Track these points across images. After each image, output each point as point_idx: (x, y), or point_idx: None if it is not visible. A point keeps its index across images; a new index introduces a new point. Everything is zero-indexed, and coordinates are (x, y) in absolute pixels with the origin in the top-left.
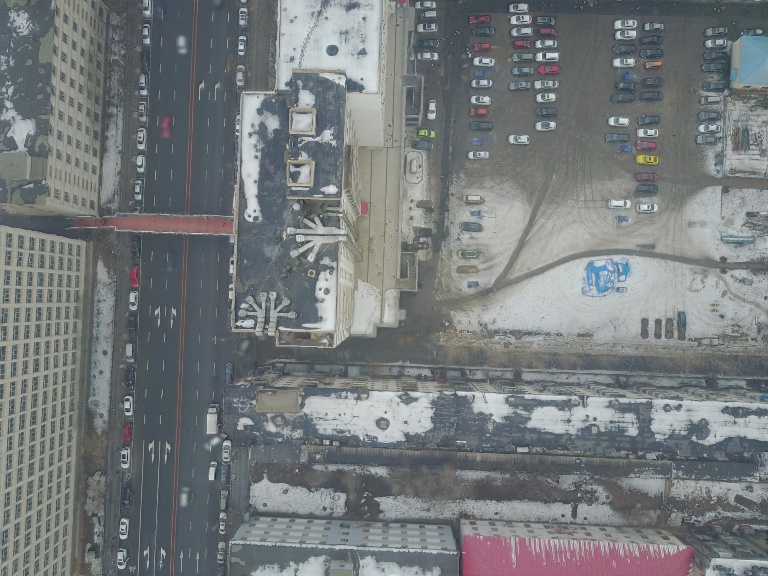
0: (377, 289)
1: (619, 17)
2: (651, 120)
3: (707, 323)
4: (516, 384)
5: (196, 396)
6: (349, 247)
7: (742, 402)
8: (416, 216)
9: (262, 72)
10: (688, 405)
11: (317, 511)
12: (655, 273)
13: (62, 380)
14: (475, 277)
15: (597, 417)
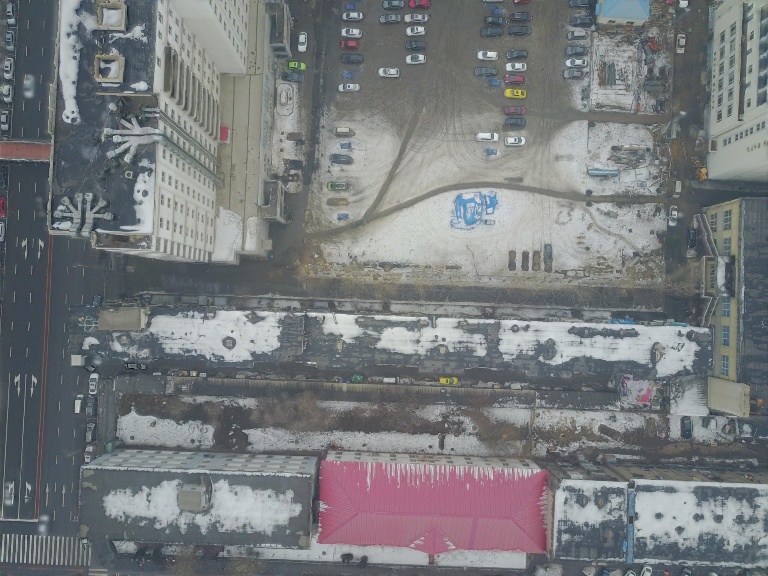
0: (239, 216)
1: None
2: (519, 54)
3: (573, 255)
4: (382, 314)
5: (63, 329)
6: (187, 160)
7: None
8: (287, 148)
9: None
10: (535, 325)
11: (185, 444)
12: (523, 206)
13: None
14: (345, 209)
15: (446, 337)
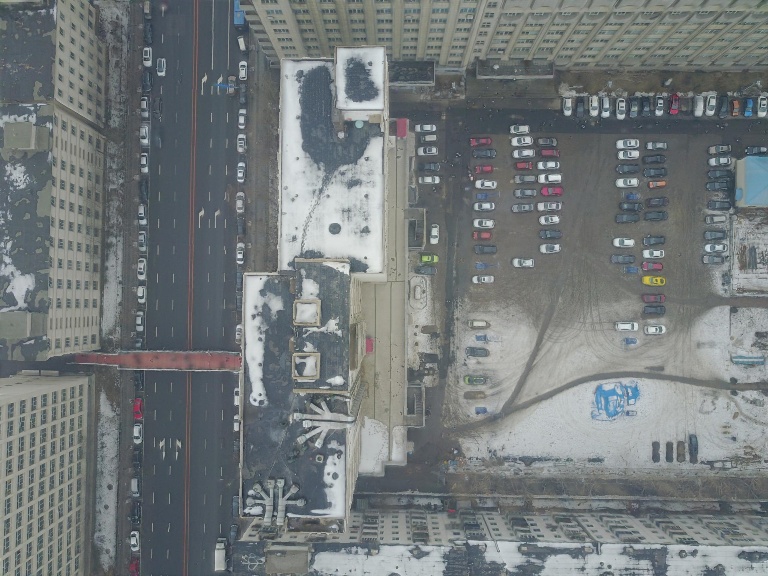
0: (384, 426)
1: (621, 136)
2: (657, 241)
3: (719, 445)
4: (527, 514)
5: (203, 529)
6: None
7: (759, 546)
8: (421, 342)
9: (262, 199)
10: (704, 550)
11: None
12: (665, 395)
13: (67, 527)
14: (483, 403)
15: (612, 564)
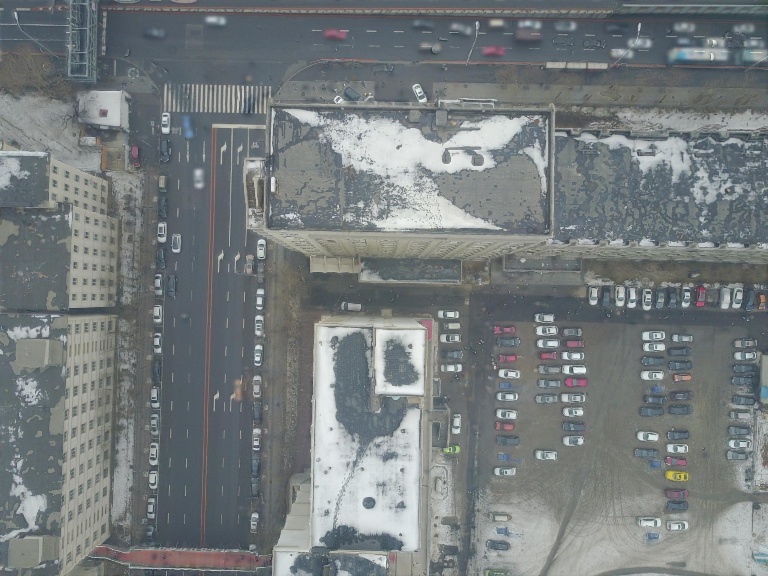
0: None
1: (647, 327)
2: (681, 436)
3: None
4: None
5: None
6: None
7: None
8: (441, 533)
9: (279, 382)
10: None
11: None
12: None
13: None
14: None
15: None
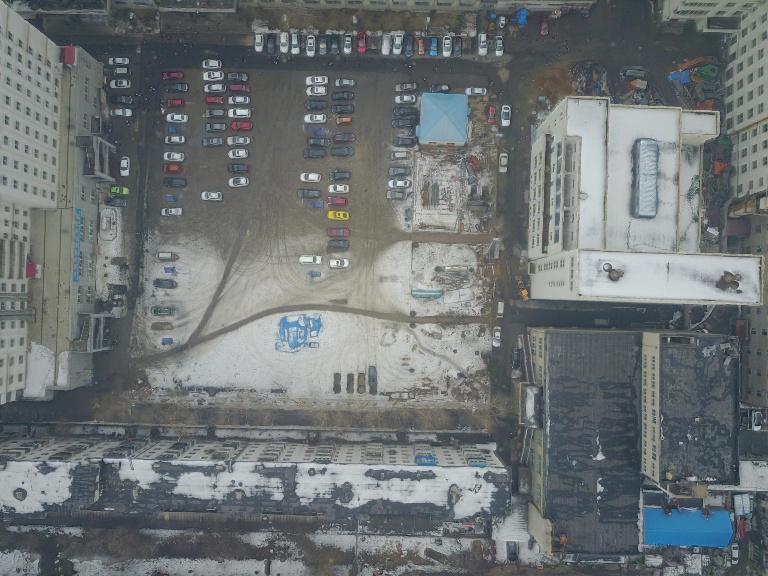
0: (51, 351)
1: (312, 73)
2: (341, 176)
3: (398, 377)
4: (203, 442)
5: None
6: None
7: (386, 464)
8: (111, 273)
9: None
10: (332, 468)
11: (10, 573)
12: (347, 328)
13: None
14: (170, 334)
15: (243, 482)
